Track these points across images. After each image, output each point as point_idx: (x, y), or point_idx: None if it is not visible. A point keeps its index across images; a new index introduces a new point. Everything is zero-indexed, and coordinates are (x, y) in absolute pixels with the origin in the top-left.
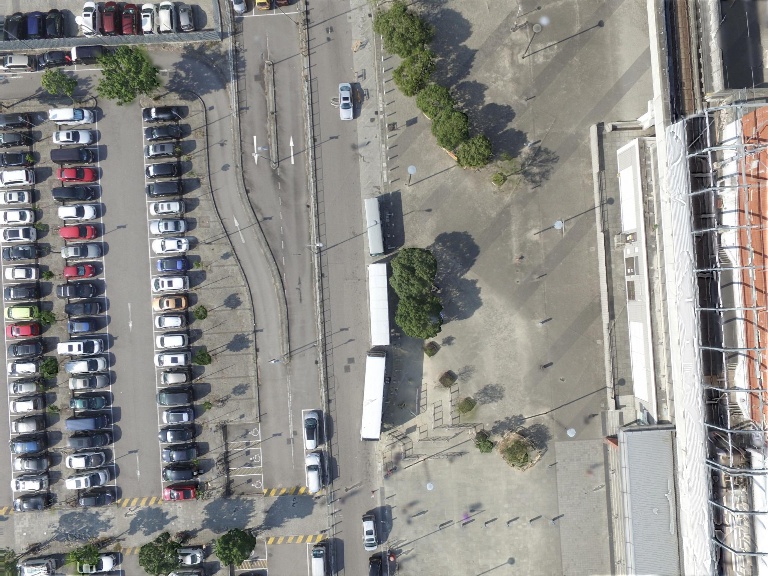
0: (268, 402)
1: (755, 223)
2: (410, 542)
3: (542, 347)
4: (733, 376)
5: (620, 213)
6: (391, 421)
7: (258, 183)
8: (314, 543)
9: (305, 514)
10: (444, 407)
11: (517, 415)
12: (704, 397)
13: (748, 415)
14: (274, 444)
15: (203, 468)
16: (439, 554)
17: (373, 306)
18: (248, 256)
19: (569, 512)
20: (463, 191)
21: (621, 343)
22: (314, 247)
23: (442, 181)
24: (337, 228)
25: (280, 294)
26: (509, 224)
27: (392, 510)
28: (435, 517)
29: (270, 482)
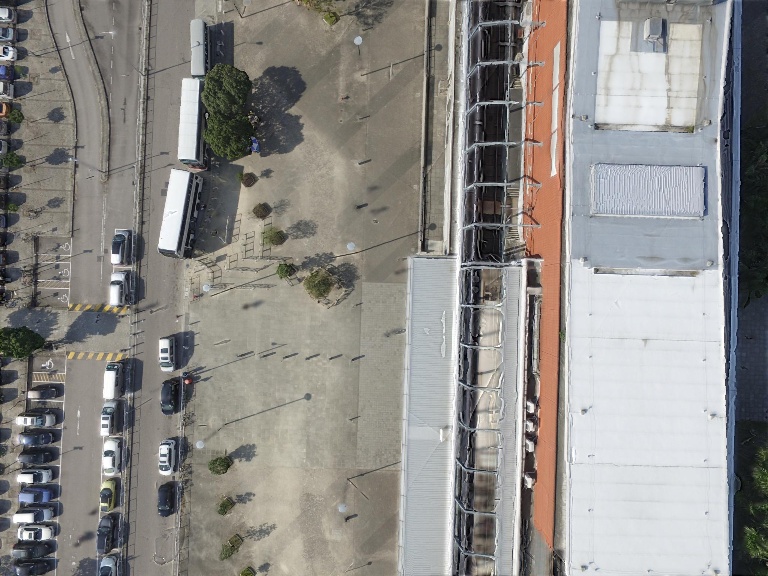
0: (82, 218)
1: (534, 36)
2: (209, 369)
3: (359, 187)
4: (517, 204)
5: (447, 60)
6: (202, 248)
7: (93, 2)
8: (113, 361)
9: (107, 332)
10: (256, 238)
11: (327, 253)
12: (466, 203)
13: (522, 238)
14: (84, 260)
15: (11, 277)
16: (237, 384)
17: (182, 120)
18: (76, 72)
19: (370, 353)
20: (295, 27)
21: (436, 188)
22: (142, 69)
23: (275, 16)
24: (167, 53)
25: (104, 112)
26: (338, 63)
27: (195, 336)
28: (237, 347)
29: (76, 297)
